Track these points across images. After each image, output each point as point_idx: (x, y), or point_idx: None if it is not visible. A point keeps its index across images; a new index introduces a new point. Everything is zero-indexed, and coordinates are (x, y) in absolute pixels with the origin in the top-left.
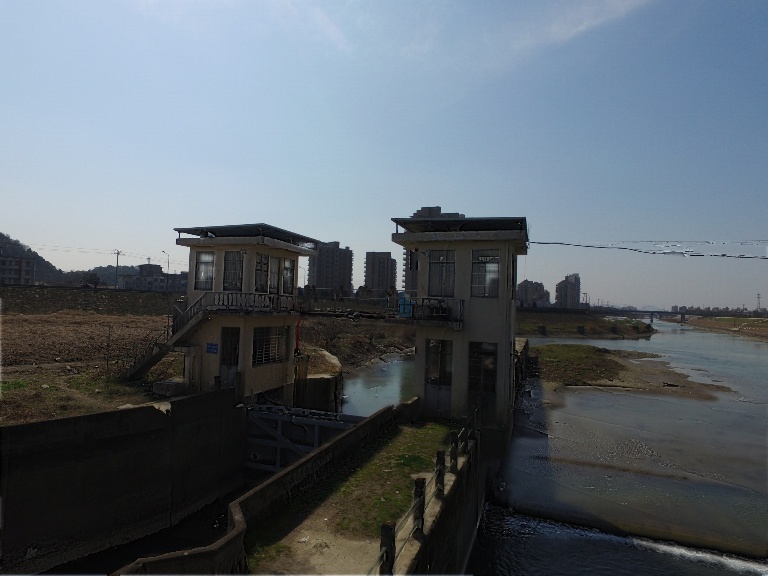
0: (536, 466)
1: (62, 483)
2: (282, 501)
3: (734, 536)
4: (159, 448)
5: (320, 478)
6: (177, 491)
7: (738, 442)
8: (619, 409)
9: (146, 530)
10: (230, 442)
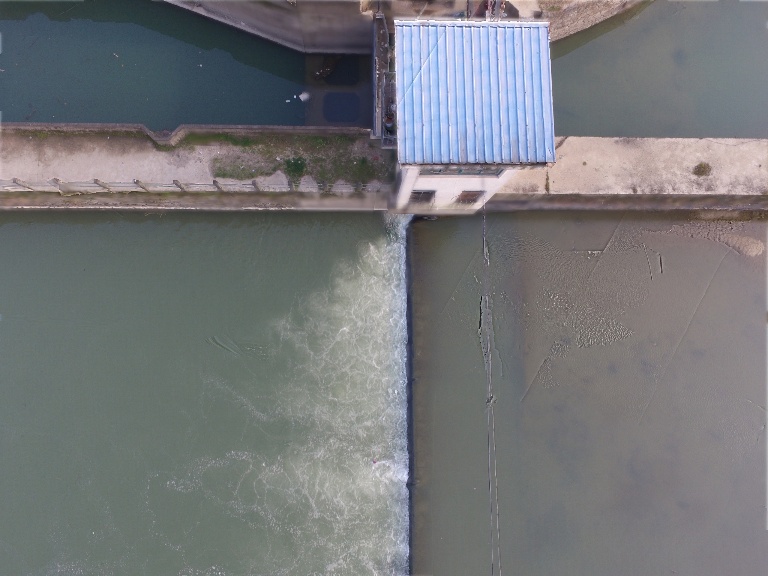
0: (503, 241)
1: (245, 6)
2: (215, 133)
3: (421, 352)
4: (290, 18)
5: (248, 135)
6: (307, 41)
7: (676, 438)
8: None
9: (292, 46)
10: (355, 31)
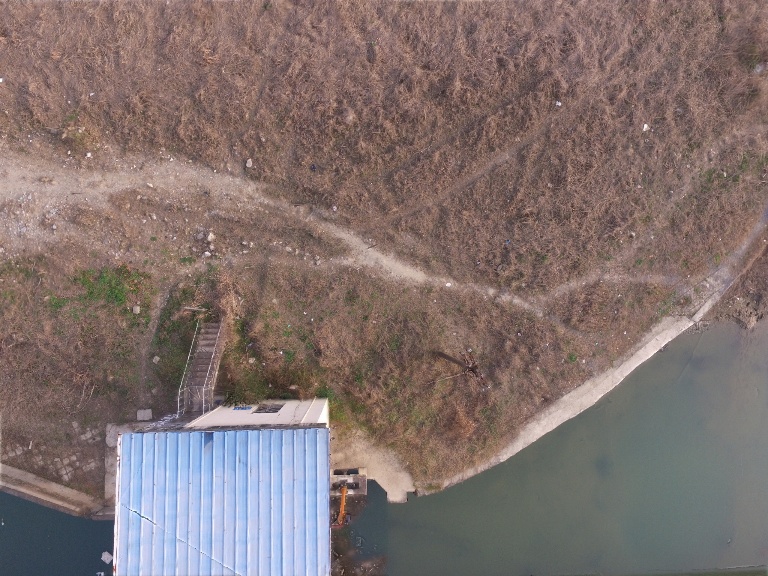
0: None
1: None
2: None
3: None
4: None
5: None
6: None
7: None
8: None
9: None
10: None
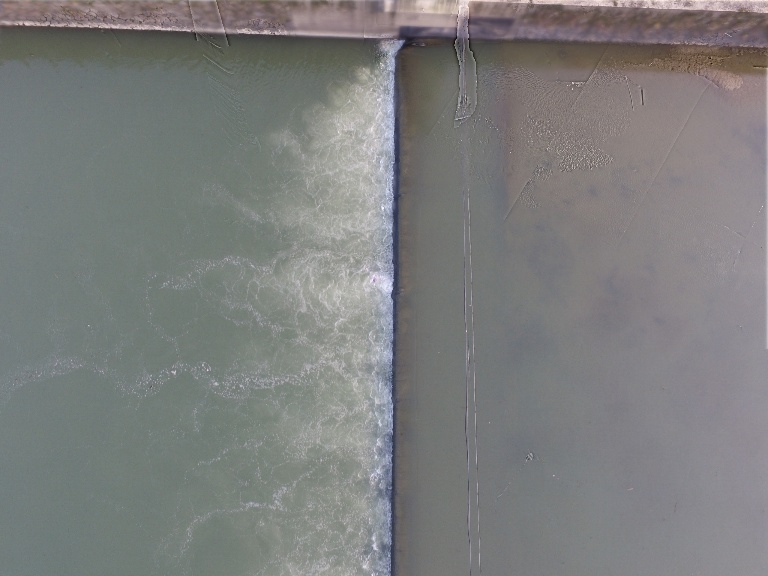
0: (489, 71)
1: None
2: None
3: (407, 169)
4: None
5: None
6: None
7: (654, 259)
8: (759, 172)
9: None
10: None
